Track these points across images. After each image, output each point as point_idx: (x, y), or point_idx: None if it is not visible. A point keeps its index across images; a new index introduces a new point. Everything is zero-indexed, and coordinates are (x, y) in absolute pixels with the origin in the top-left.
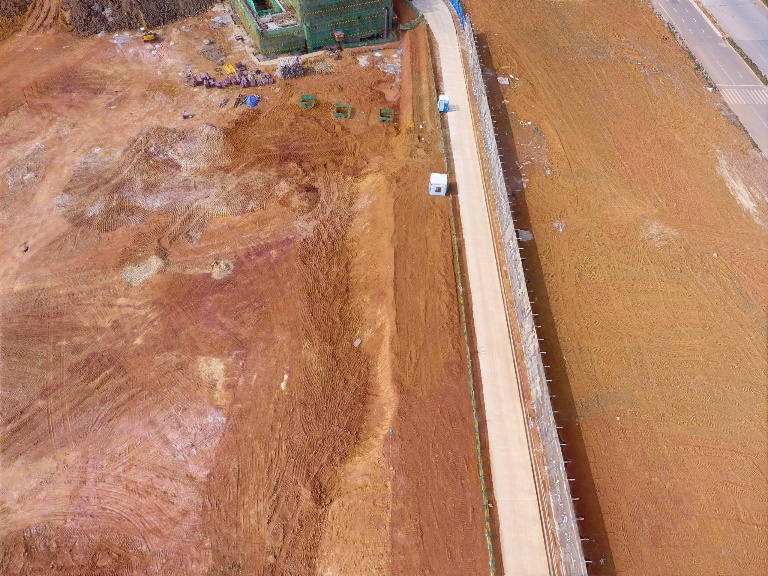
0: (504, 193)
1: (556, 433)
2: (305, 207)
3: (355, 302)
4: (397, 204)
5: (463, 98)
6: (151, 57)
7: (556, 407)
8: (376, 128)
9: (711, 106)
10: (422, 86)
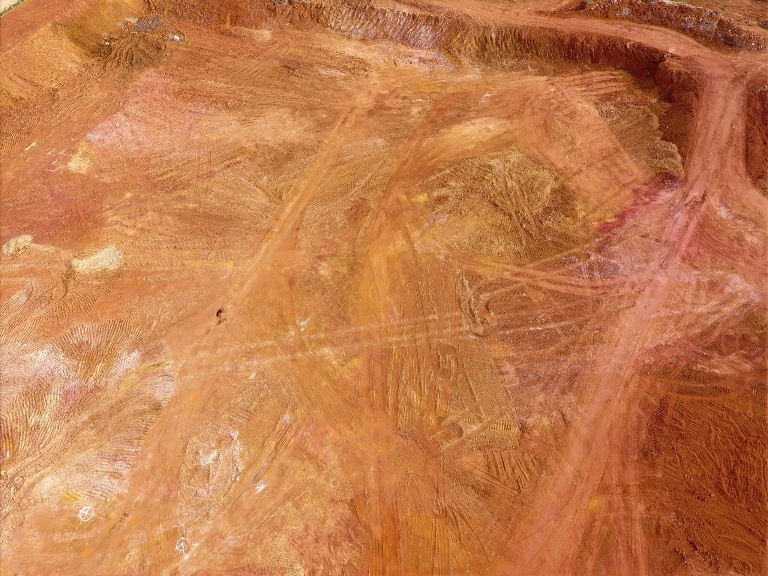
0: None
1: None
2: None
3: None
4: None
5: None
6: None
7: None
8: None
9: None
10: None
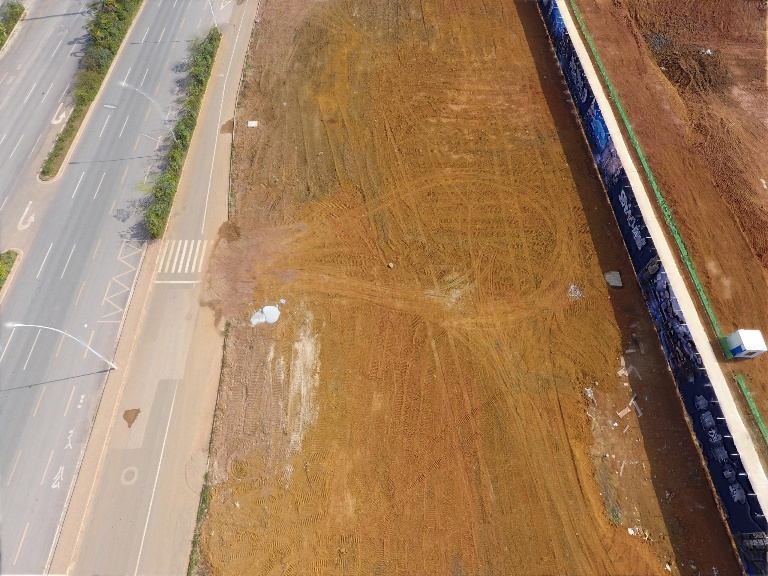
0: None
1: None
2: None
3: None
4: None
5: None
6: None
7: (573, 137)
8: None
9: None
10: None
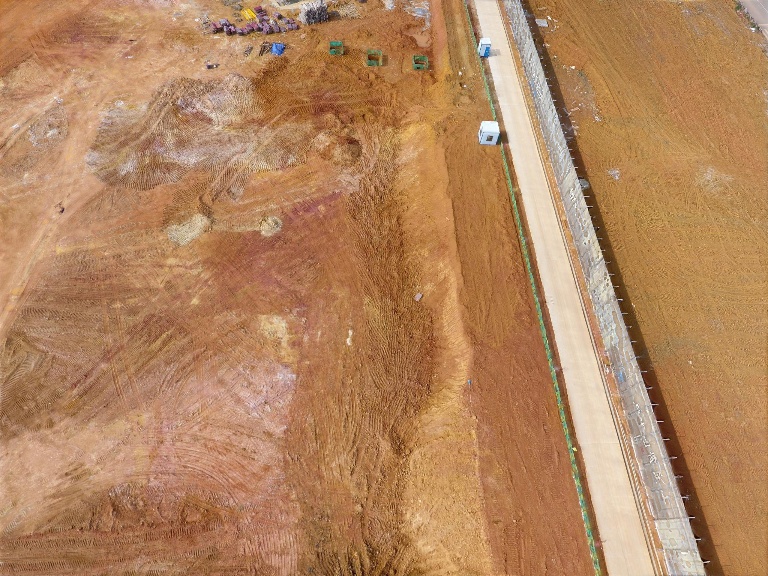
0: (561, 140)
1: (641, 377)
2: (348, 160)
3: (412, 256)
4: (448, 154)
5: (503, 42)
6: (162, 2)
7: None
8: (411, 76)
9: (755, 47)
10: (457, 30)
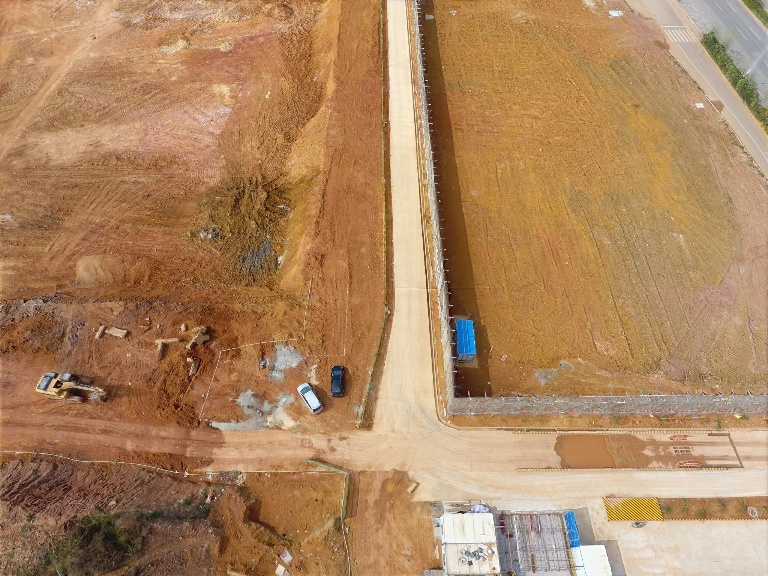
0: None
1: None
2: (283, 16)
3: (315, 59)
4: (344, 3)
5: None
6: None
7: (433, 86)
8: None
9: None
10: None
